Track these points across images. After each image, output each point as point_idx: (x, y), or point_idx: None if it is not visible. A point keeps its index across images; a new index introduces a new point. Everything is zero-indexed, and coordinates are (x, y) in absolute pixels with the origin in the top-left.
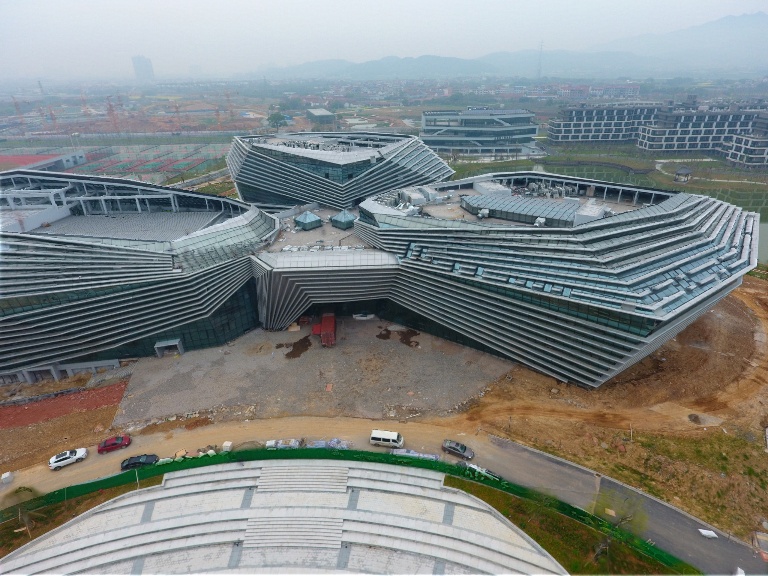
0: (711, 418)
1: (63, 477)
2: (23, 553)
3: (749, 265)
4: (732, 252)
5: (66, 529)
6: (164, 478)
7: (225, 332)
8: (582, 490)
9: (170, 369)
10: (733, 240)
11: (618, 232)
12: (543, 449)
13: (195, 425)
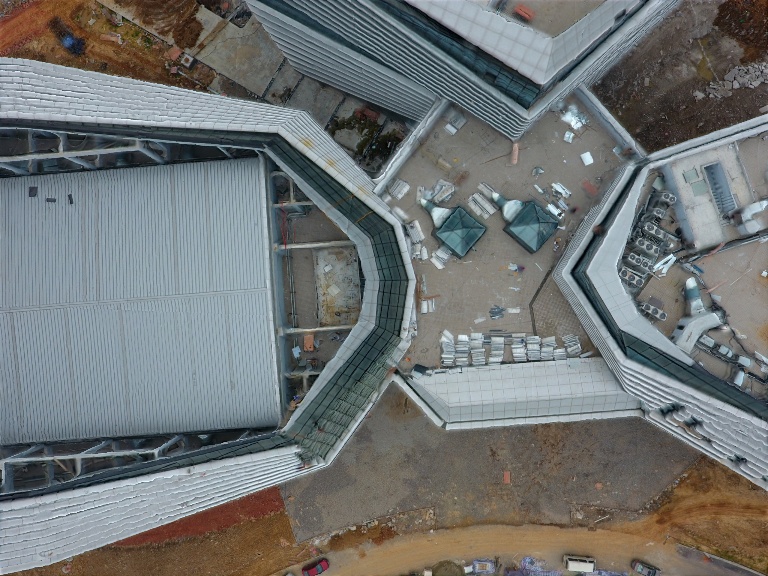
0: None
1: None
2: None
3: None
4: None
5: None
6: None
7: None
8: None
9: None
10: None
11: None
12: (724, 555)
13: (382, 540)
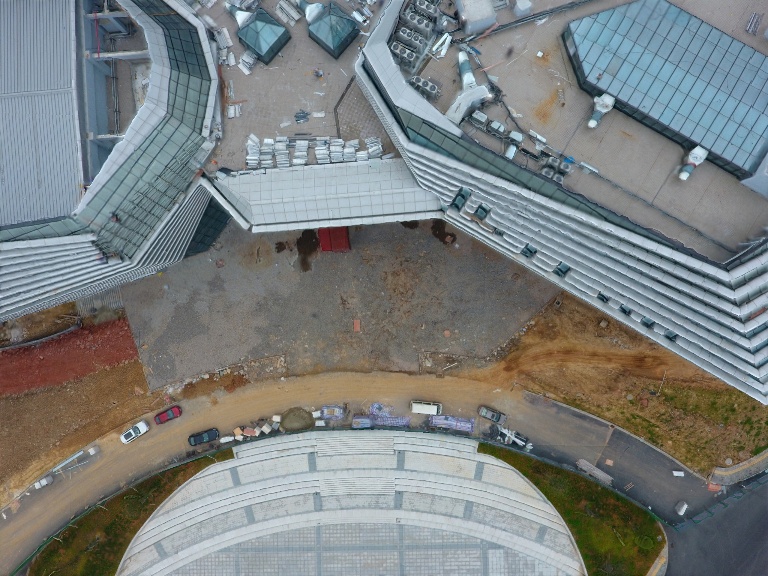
0: None
1: (143, 447)
2: (159, 513)
3: None
4: None
5: (178, 493)
6: (234, 452)
7: (205, 242)
8: (593, 444)
9: (164, 298)
10: None
11: None
12: (571, 403)
13: (233, 387)
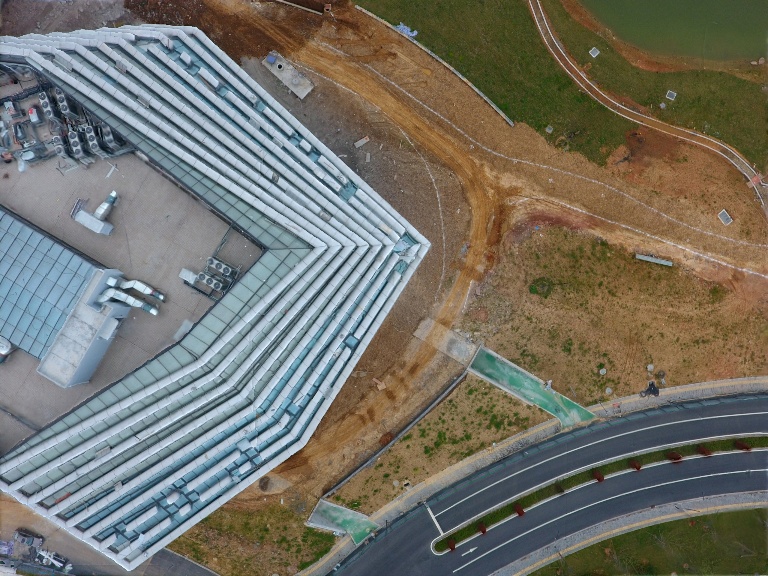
0: (280, 482)
1: None
2: None
3: (297, 442)
4: (277, 428)
5: None
6: None
7: None
8: None
9: None
10: (305, 382)
11: (78, 454)
12: None
13: None
